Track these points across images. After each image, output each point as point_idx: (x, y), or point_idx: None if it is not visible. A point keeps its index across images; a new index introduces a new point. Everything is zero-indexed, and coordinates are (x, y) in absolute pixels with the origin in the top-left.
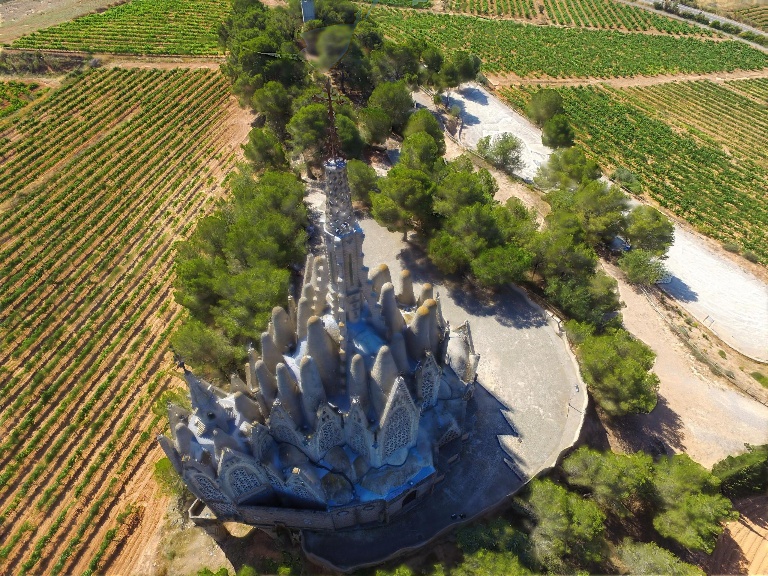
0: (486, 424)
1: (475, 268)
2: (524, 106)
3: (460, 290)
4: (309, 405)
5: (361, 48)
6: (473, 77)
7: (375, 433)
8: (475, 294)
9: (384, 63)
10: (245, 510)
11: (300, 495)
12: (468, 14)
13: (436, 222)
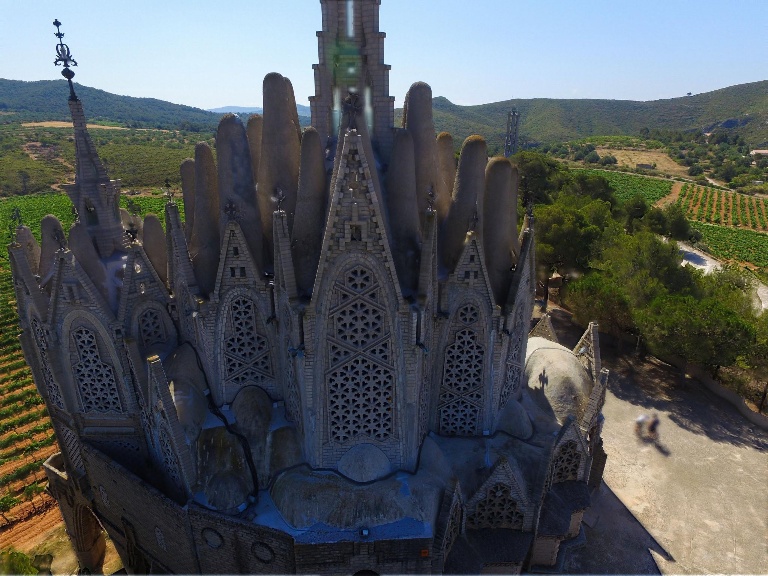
0: (607, 561)
1: (638, 315)
2: (762, 269)
3: (611, 371)
4: (222, 237)
5: (551, 177)
6: (688, 236)
7: (302, 317)
8: (638, 381)
9: (574, 193)
10: (88, 458)
11: (170, 467)
12: (694, 220)
13: (589, 274)
